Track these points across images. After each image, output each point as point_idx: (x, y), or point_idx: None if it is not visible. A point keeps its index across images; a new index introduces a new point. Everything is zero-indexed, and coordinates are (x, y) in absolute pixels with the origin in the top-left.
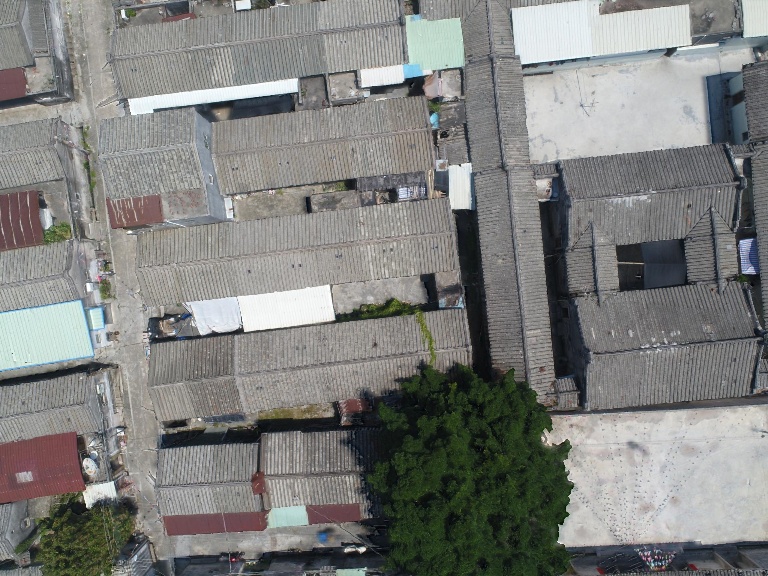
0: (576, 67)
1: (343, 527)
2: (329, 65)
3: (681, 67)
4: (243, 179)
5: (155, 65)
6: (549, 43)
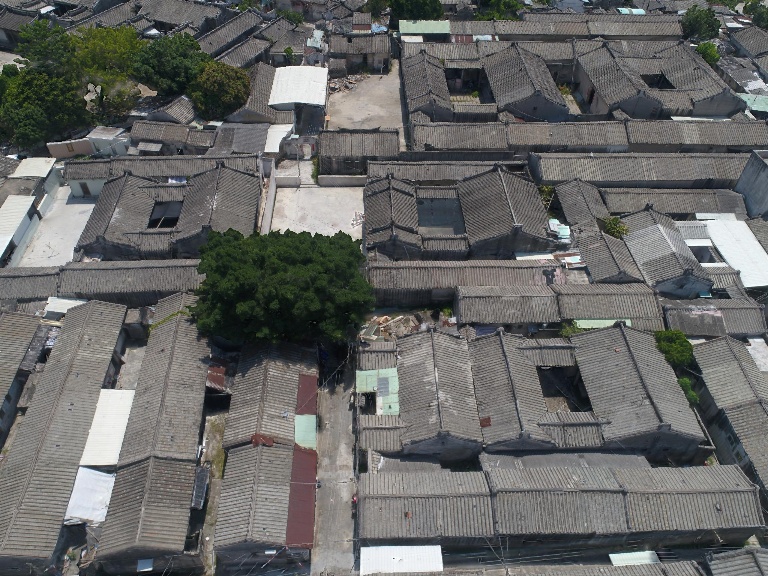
0: (20, 258)
1: (334, 409)
2: None
3: (53, 214)
4: None
5: None
6: None
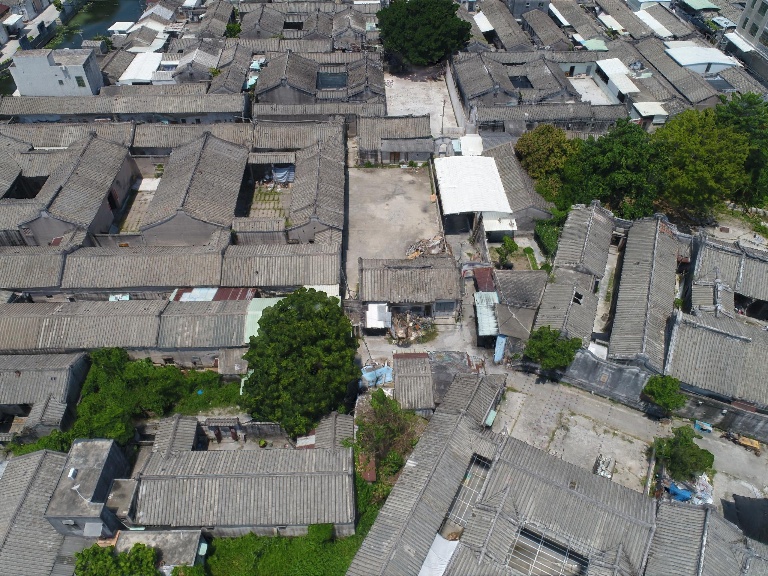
0: (603, 91)
1: None
2: None
3: None
4: None
5: (564, 2)
6: None
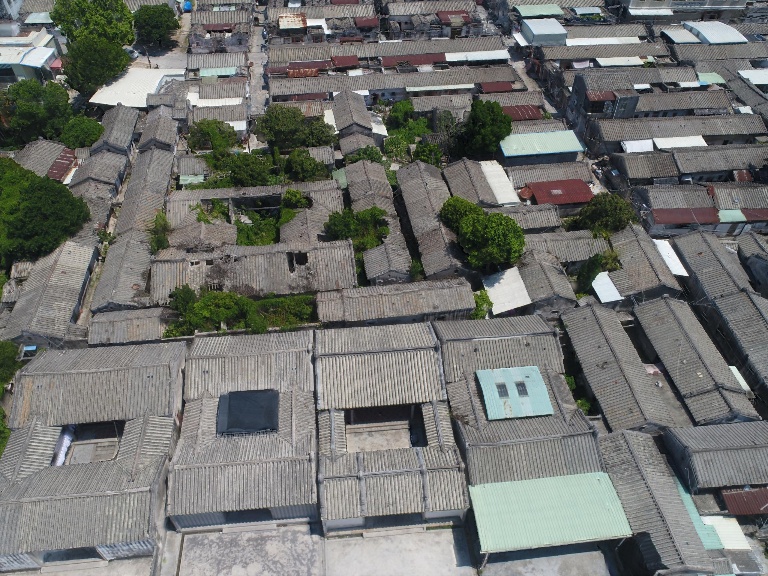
0: None
1: None
2: (663, 80)
3: None
4: (637, 106)
5: None
6: (761, 79)
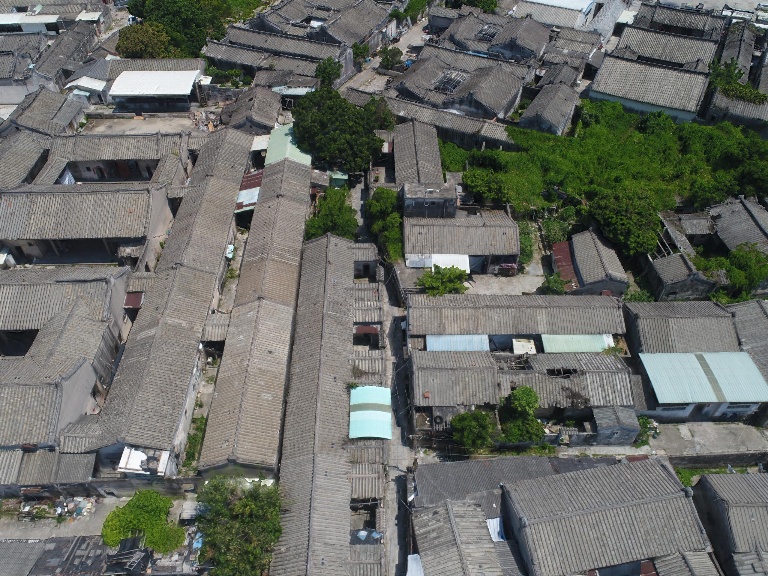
0: None
1: None
2: None
3: None
4: None
5: None
6: None
